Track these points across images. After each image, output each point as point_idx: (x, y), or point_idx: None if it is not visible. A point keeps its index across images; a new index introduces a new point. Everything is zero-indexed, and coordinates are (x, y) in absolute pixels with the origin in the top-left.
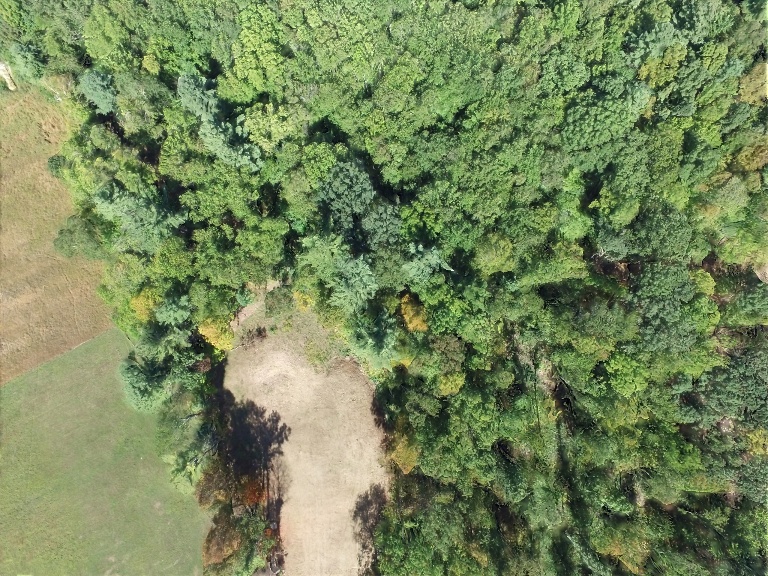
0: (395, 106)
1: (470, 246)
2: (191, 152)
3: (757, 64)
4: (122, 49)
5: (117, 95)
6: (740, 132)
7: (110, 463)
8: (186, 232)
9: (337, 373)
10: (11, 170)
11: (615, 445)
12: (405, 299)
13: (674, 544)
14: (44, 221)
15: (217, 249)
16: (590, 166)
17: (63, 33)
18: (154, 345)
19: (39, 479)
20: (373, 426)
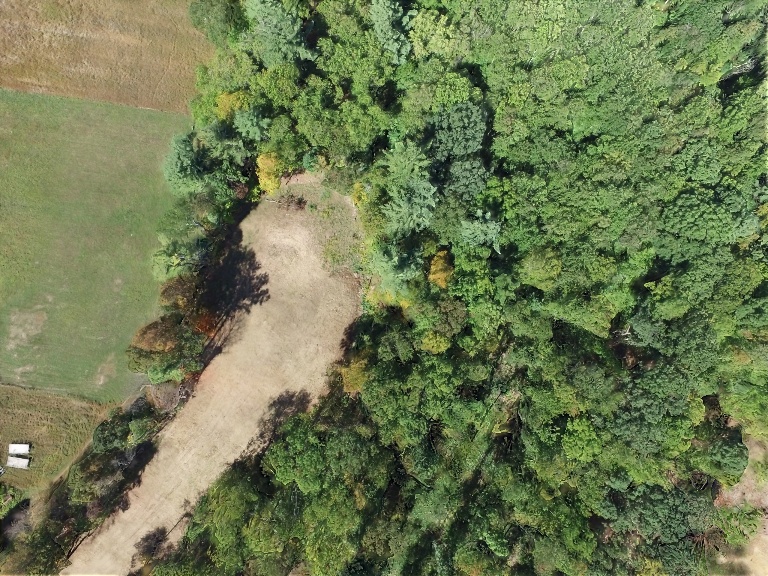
0: (543, 93)
1: (525, 248)
2: (354, 11)
3: None
4: None
5: None
6: None
7: (104, 220)
8: (305, 71)
9: (339, 280)
10: None
11: (527, 495)
12: (442, 253)
13: None
14: None
15: (321, 101)
16: (667, 254)
17: None
18: (218, 139)
19: (37, 192)
20: (338, 344)
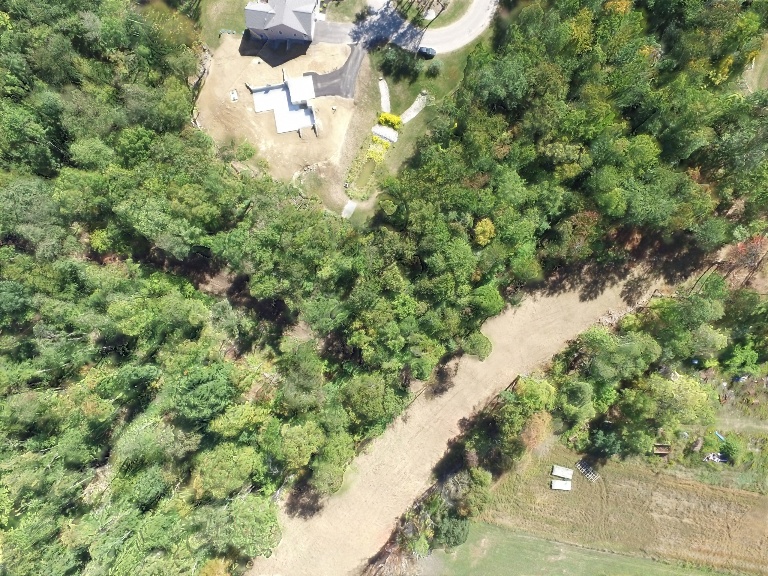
0: None
1: None
2: None
3: None
4: None
5: None
6: None
7: None
8: None
9: None
10: None
11: None
12: None
13: None
14: None
15: None
16: None
17: None
18: None
19: None
20: None
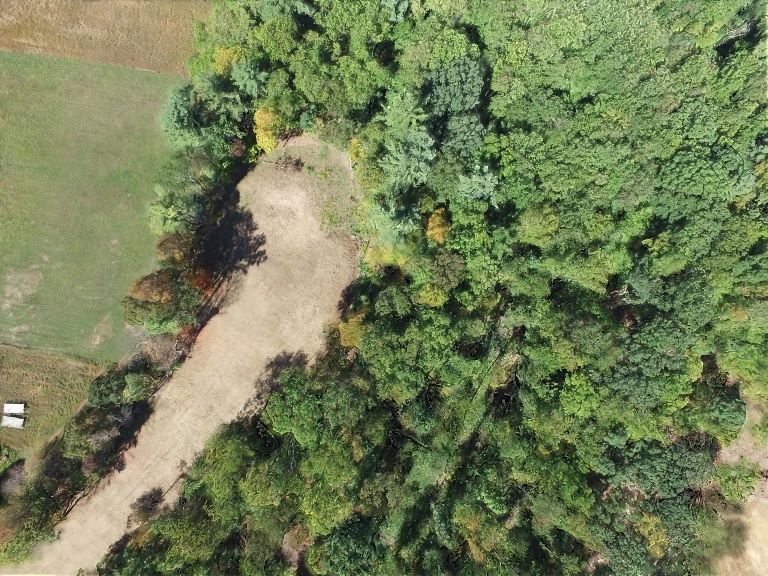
0: (540, 53)
1: (522, 206)
2: None
3: None
4: None
5: None
6: None
7: (100, 180)
8: (302, 27)
9: (336, 241)
10: None
11: (525, 453)
12: (439, 211)
13: (516, 570)
14: None
15: (318, 56)
16: (664, 212)
17: None
18: (215, 90)
19: (33, 152)
20: (335, 305)
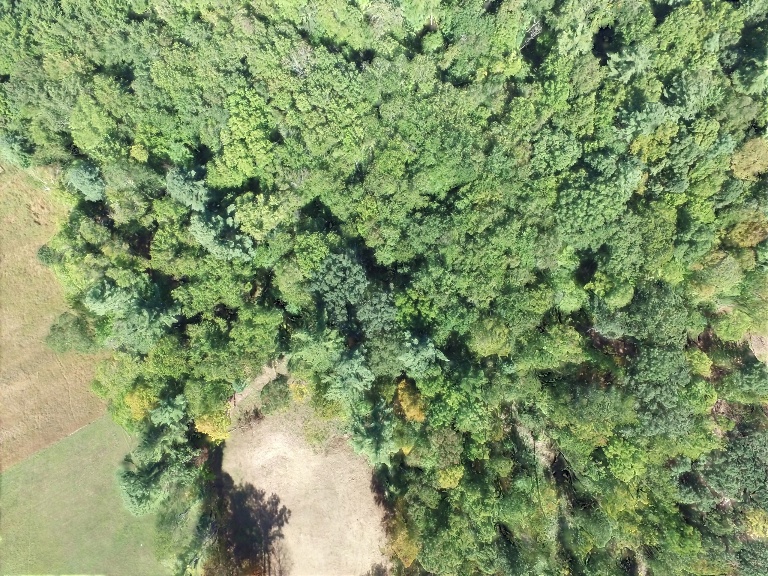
0: (387, 189)
1: (466, 330)
2: (182, 244)
3: (749, 140)
4: (109, 140)
5: (106, 186)
6: (733, 209)
7: (110, 551)
8: (179, 327)
9: (336, 452)
10: (1, 254)
11: (615, 523)
12: (402, 385)
13: None
14: (36, 305)
15: (211, 345)
16: (584, 244)
17: (49, 123)
18: (150, 449)
19: (39, 569)
20: (373, 504)
